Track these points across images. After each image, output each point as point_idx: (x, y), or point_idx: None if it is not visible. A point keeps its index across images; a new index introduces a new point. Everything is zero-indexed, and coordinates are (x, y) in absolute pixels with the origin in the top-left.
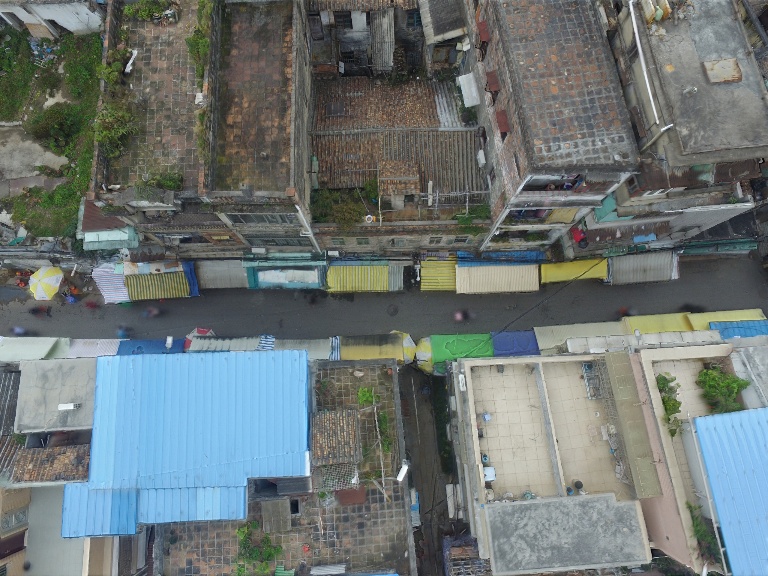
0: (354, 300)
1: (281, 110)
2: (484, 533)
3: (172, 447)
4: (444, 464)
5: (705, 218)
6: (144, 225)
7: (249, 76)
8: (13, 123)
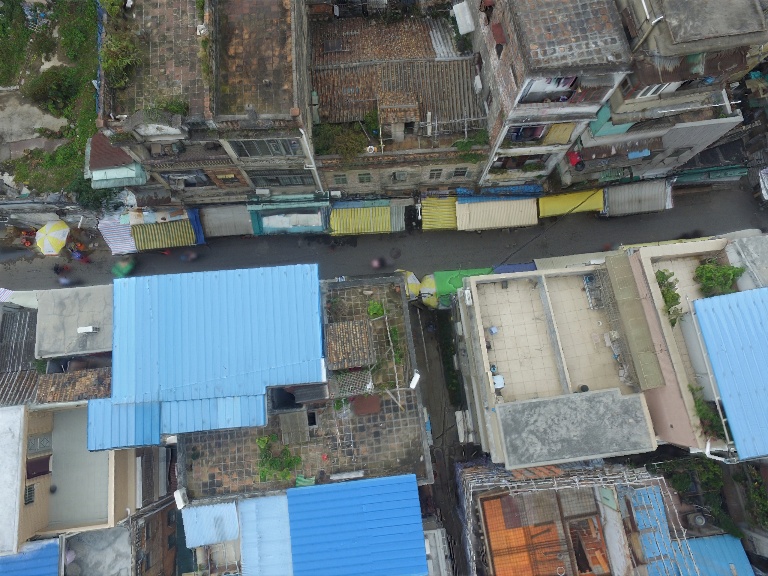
0: (357, 245)
1: (281, 40)
2: (495, 438)
3: (191, 361)
4: (452, 397)
5: (696, 137)
6: (151, 161)
7: (248, 9)
8: (10, 88)
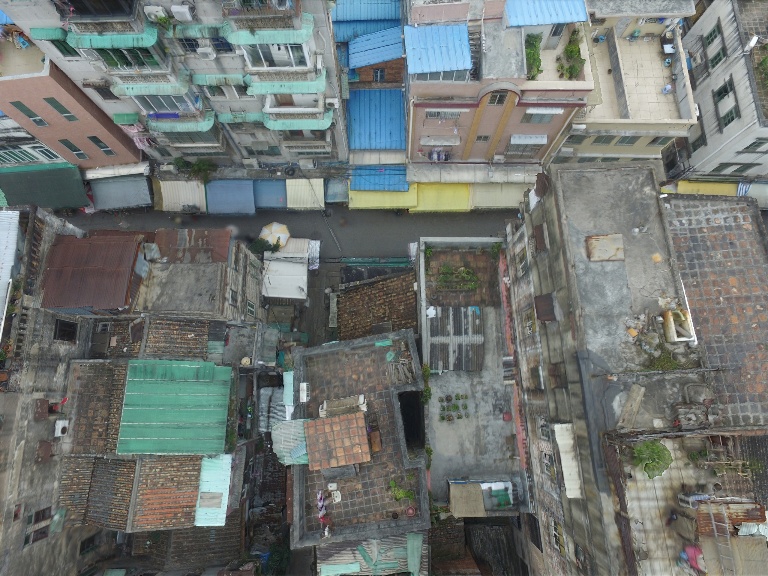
0: None
1: None
2: None
3: None
4: None
5: None
6: None
7: None
8: None
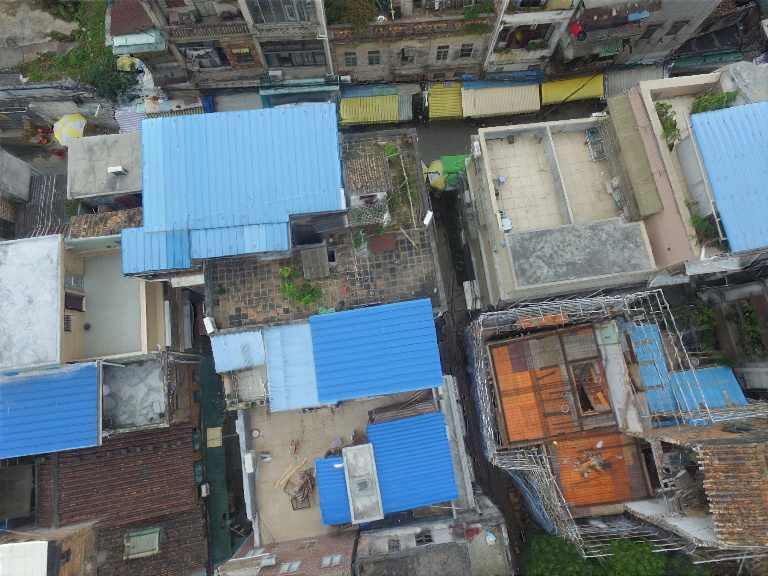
0: None
1: None
2: (504, 276)
3: (218, 192)
4: (459, 277)
5: (693, 6)
6: (170, 27)
7: None
8: None
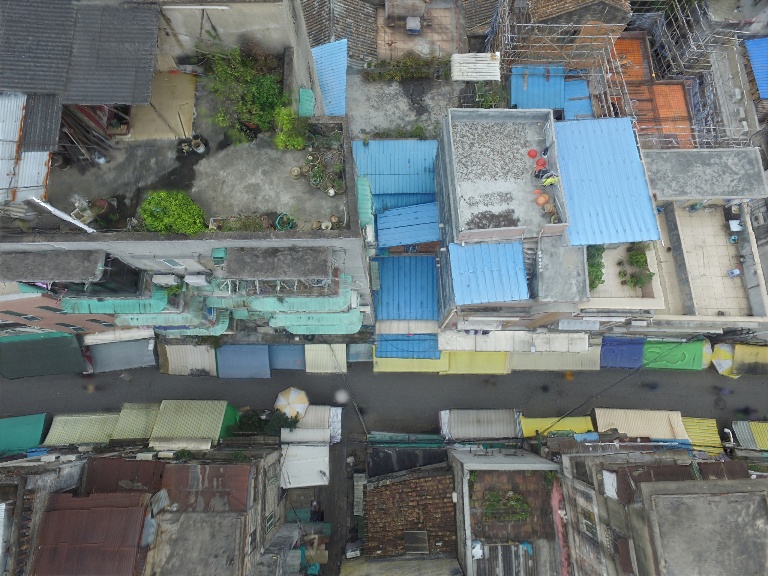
0: (763, 418)
1: None
2: None
3: None
4: None
5: None
6: None
7: None
8: None
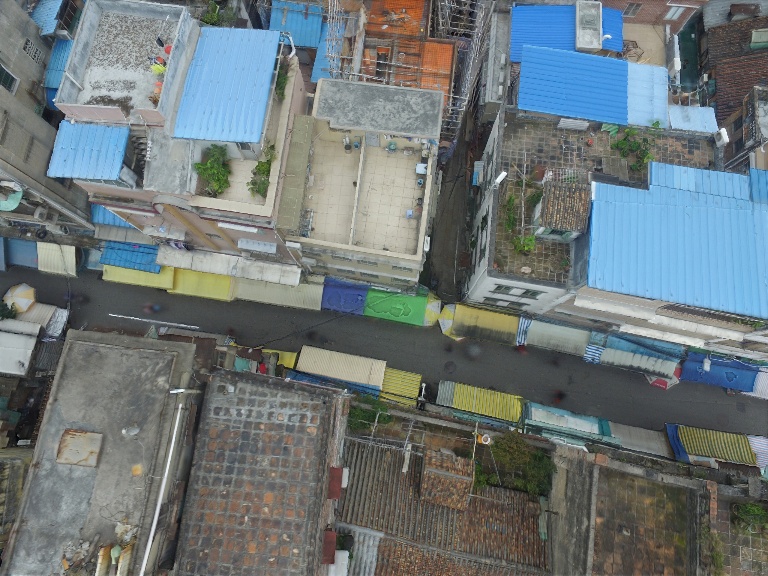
0: (489, 388)
1: None
2: None
3: (722, 228)
4: None
5: None
6: None
7: None
8: None
